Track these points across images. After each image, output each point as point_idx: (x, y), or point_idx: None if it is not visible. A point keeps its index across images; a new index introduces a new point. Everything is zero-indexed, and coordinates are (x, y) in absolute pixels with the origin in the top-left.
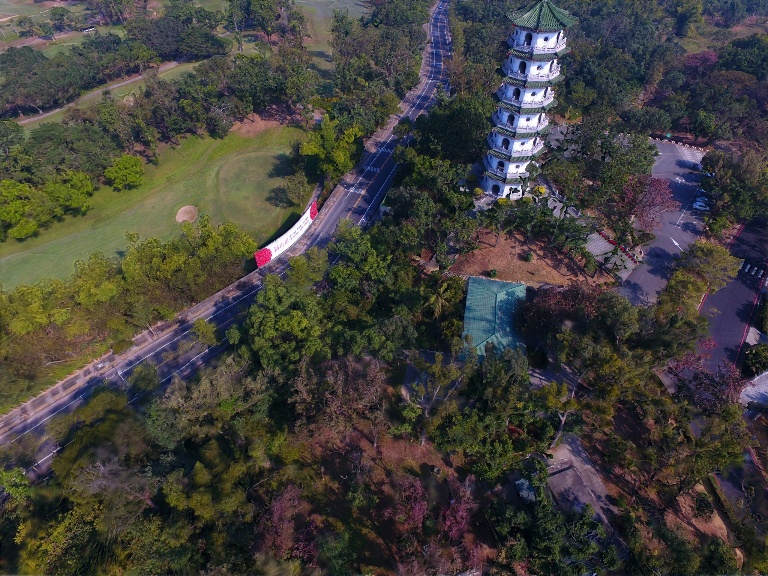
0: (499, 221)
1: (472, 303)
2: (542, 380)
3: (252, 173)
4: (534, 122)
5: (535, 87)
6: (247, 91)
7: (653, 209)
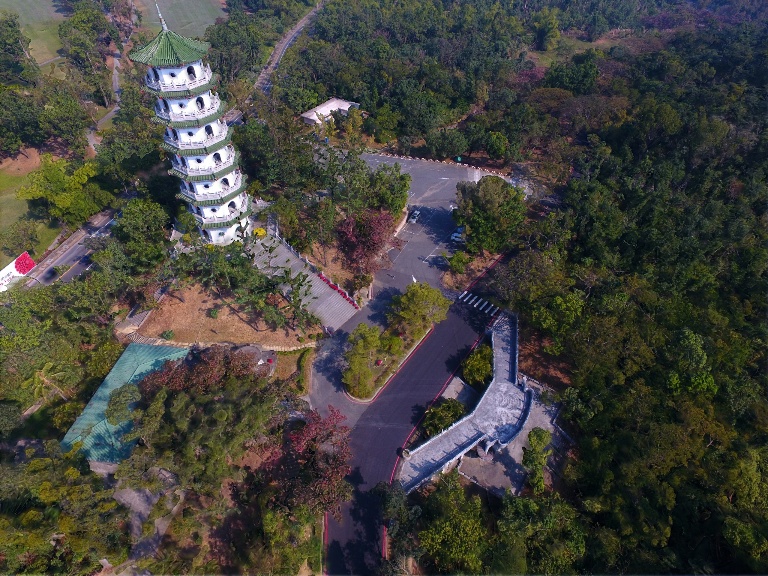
0: (199, 271)
1: (111, 378)
2: (162, 470)
3: (2, 217)
4: (209, 163)
5: (182, 127)
6: (7, 125)
7: (376, 248)
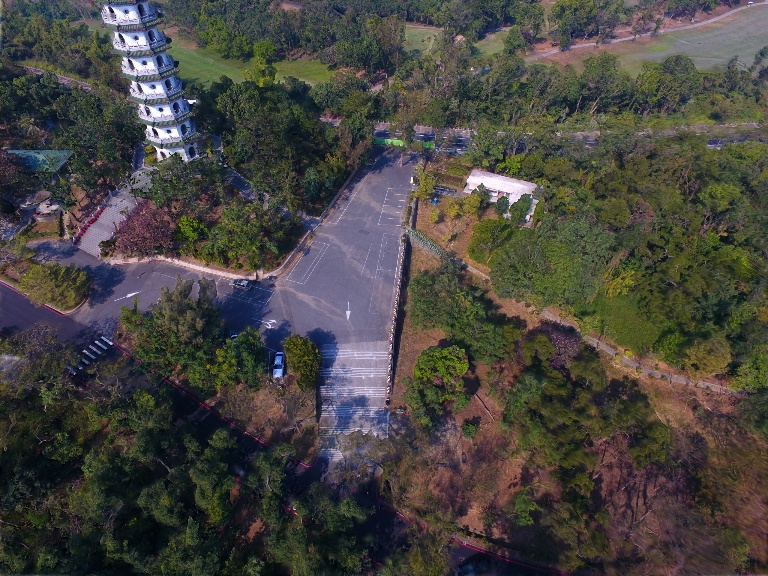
0: None
1: None
2: None
3: None
4: None
5: None
6: None
7: None
